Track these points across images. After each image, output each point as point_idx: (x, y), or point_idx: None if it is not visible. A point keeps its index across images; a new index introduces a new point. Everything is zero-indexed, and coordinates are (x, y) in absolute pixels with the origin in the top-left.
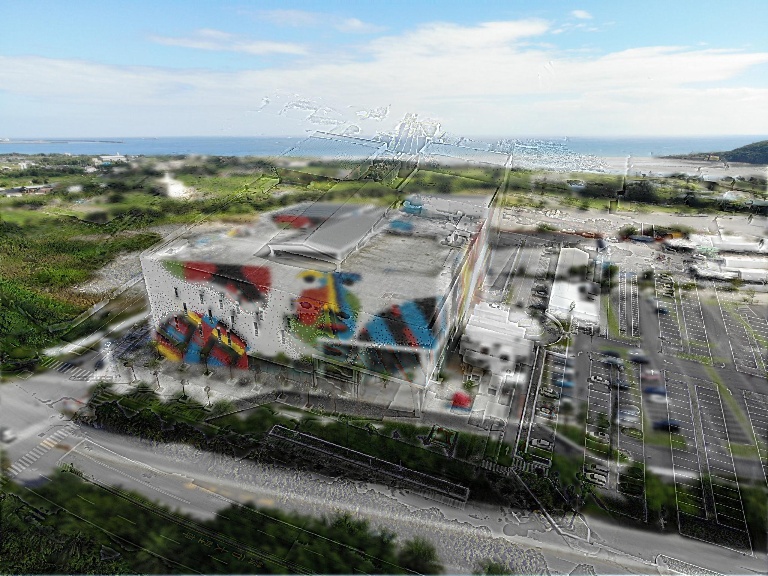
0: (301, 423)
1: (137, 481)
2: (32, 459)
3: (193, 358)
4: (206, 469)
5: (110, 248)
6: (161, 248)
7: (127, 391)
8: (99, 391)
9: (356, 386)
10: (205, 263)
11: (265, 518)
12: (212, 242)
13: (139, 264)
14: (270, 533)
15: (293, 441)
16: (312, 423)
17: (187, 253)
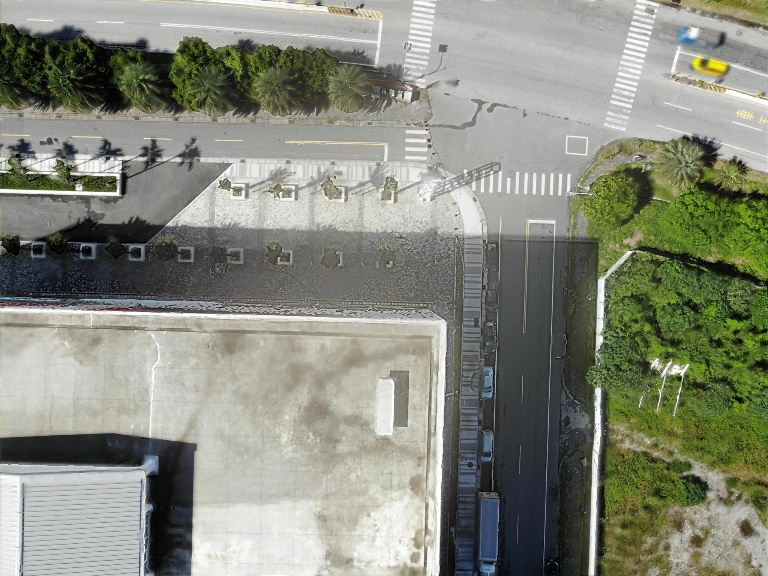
0: (86, 215)
1: (253, 29)
2: (420, 7)
3: (337, 286)
4: (162, 69)
5: (749, 553)
6: (433, 386)
7: (390, 175)
8: (433, 158)
9: (3, 297)
10: (287, 365)
11: (54, 40)
12: (331, 463)
13: (638, 517)
14: (36, 22)
15: (77, 173)
16: (70, 222)
17: (357, 389)
